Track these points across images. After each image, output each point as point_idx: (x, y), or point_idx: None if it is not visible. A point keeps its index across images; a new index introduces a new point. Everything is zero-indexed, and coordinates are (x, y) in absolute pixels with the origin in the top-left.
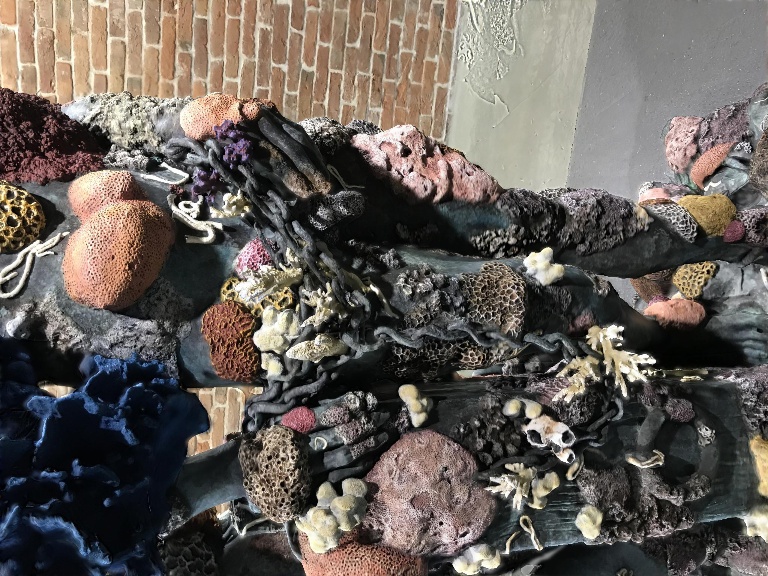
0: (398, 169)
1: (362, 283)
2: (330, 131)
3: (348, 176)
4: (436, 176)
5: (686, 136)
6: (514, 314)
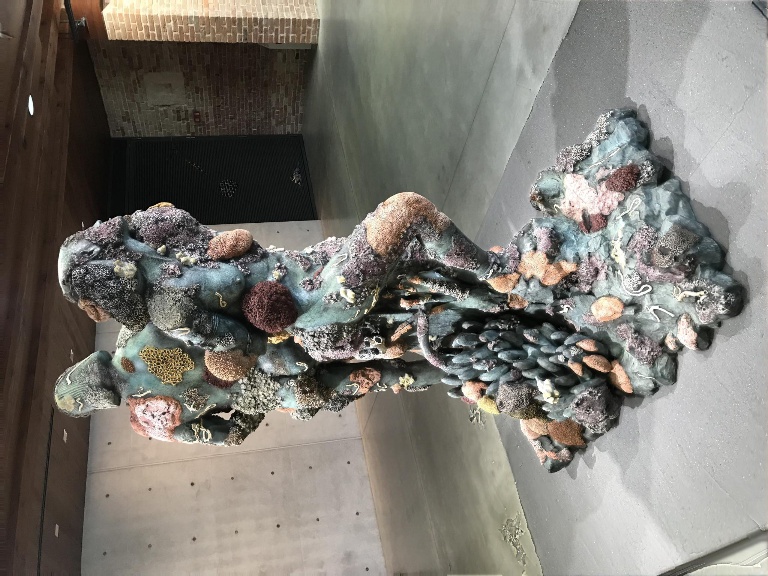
0: None
1: None
2: None
3: None
4: None
5: None
6: None
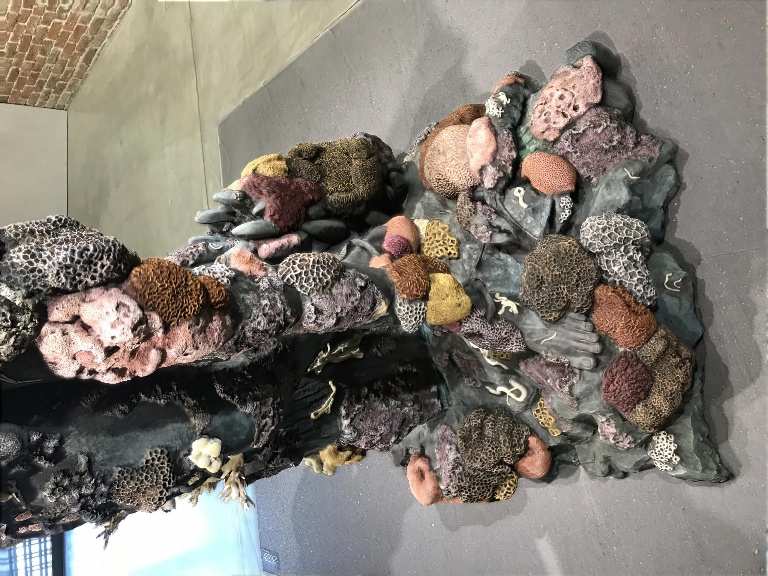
0: (93, 368)
1: (3, 498)
2: (2, 353)
3: (21, 377)
4: (141, 368)
5: (567, 108)
6: (149, 508)
